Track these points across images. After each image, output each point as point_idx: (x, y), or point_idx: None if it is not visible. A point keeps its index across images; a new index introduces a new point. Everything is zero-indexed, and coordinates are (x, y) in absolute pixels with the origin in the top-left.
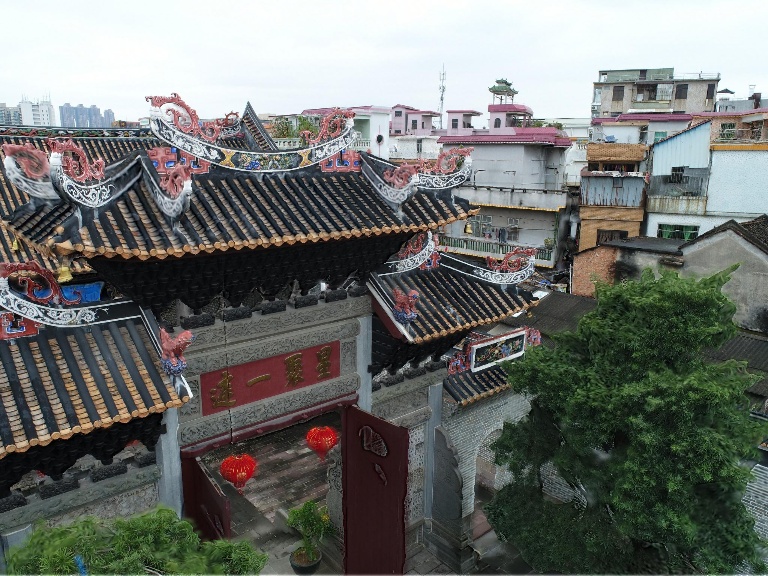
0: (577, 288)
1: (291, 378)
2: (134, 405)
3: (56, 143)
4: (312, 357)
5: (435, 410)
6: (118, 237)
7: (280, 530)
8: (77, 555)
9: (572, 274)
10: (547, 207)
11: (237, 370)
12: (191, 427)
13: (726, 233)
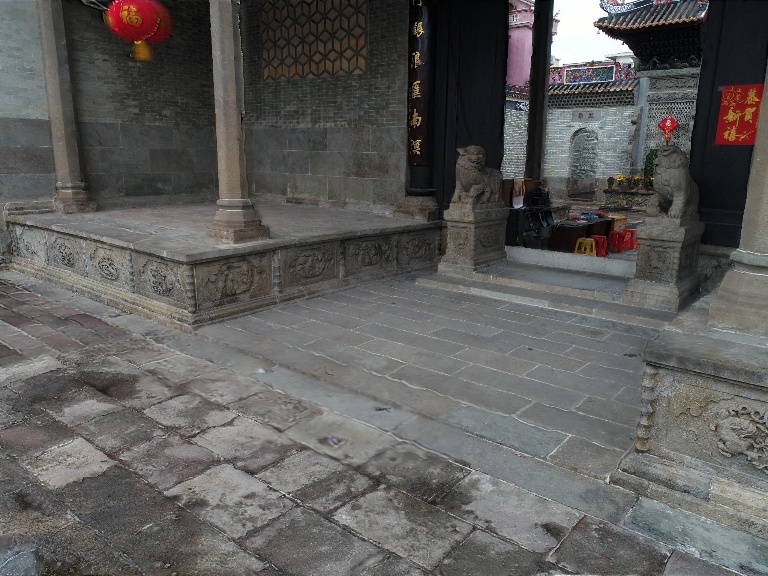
0: None
1: None
2: None
3: None
4: None
5: None
6: None
7: None
8: None
9: None
10: None
11: None
12: None
13: None
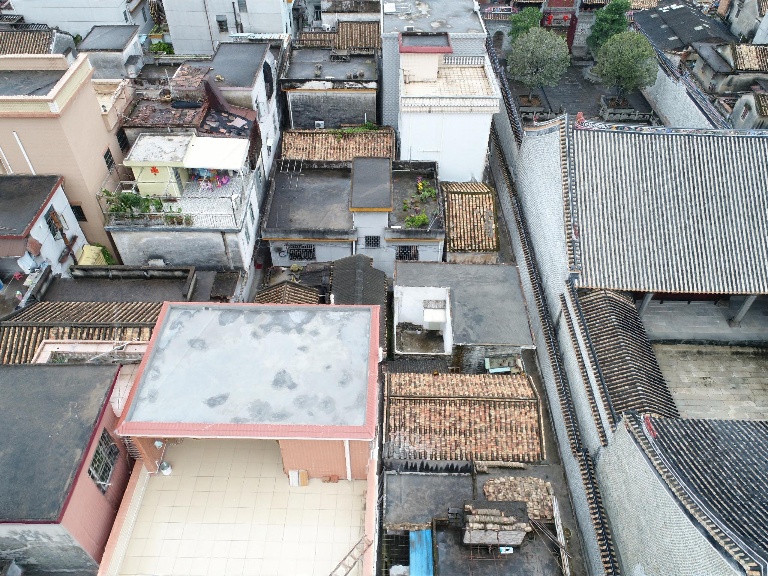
0: (718, 9)
1: (563, 5)
2: (538, 1)
3: None
4: (568, 2)
5: (594, 21)
6: None
7: None
8: (531, 8)
9: None
10: None
11: (555, 1)
12: (545, 8)
13: None
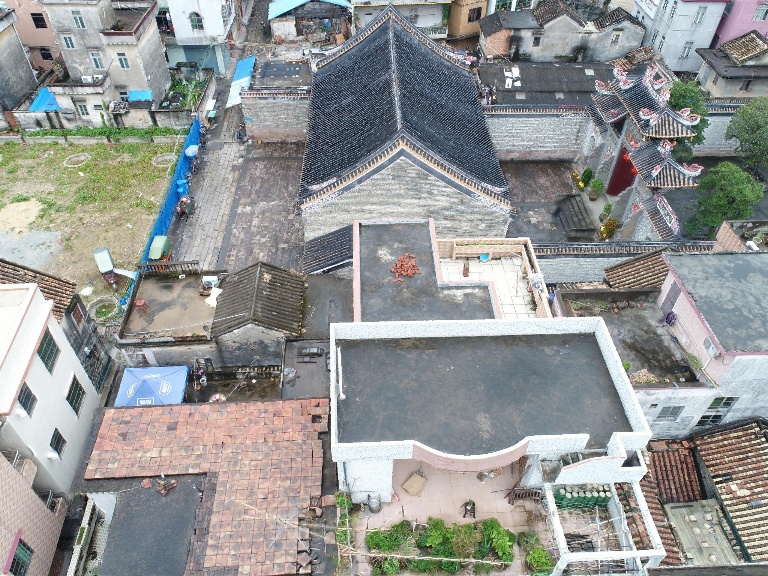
0: (489, 53)
1: None
2: None
3: None
4: None
5: None
6: None
7: (558, 200)
8: None
9: (486, 46)
10: (444, 1)
11: None
12: None
13: (563, 16)
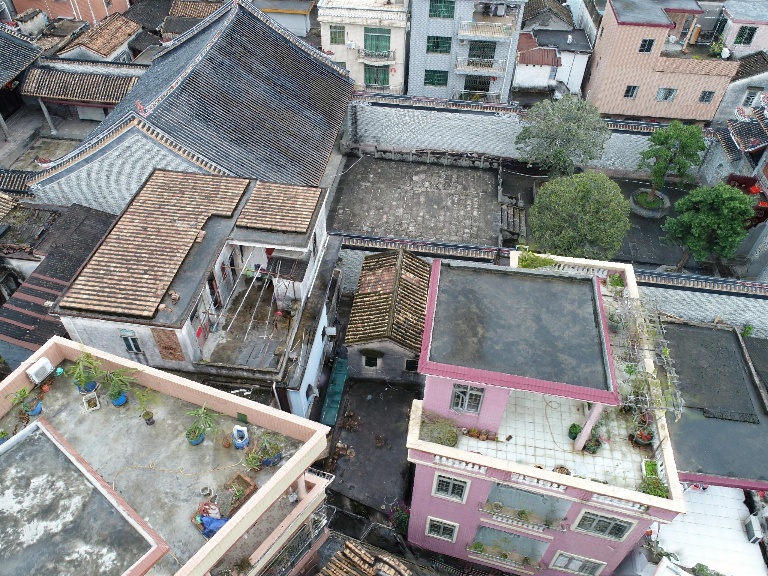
0: None
1: None
2: None
3: (763, 93)
4: None
5: None
6: (760, 114)
7: None
8: None
9: None
10: None
11: None
12: None
13: None
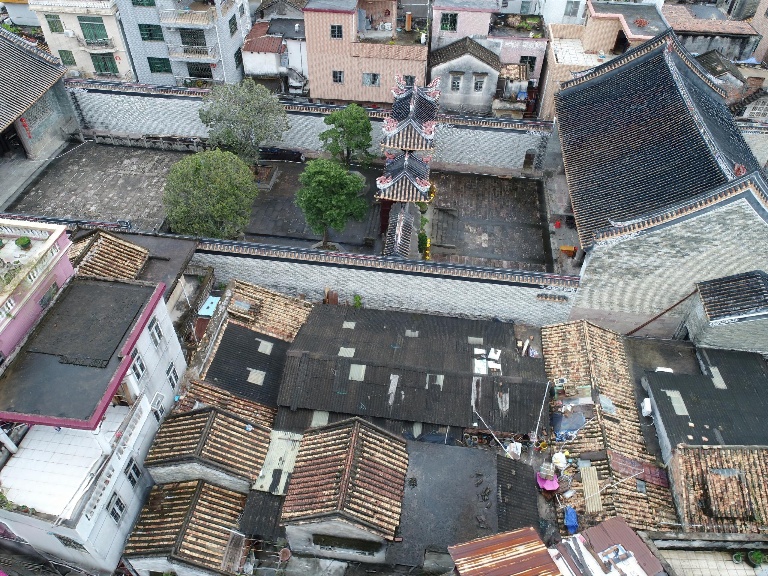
0: None
1: None
2: None
3: None
4: None
5: None
6: None
7: None
8: None
9: None
10: None
11: None
12: None
13: None
